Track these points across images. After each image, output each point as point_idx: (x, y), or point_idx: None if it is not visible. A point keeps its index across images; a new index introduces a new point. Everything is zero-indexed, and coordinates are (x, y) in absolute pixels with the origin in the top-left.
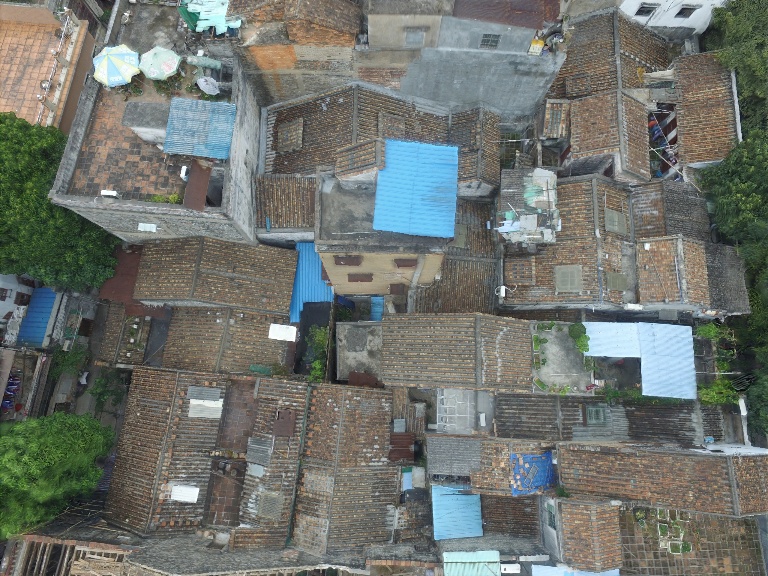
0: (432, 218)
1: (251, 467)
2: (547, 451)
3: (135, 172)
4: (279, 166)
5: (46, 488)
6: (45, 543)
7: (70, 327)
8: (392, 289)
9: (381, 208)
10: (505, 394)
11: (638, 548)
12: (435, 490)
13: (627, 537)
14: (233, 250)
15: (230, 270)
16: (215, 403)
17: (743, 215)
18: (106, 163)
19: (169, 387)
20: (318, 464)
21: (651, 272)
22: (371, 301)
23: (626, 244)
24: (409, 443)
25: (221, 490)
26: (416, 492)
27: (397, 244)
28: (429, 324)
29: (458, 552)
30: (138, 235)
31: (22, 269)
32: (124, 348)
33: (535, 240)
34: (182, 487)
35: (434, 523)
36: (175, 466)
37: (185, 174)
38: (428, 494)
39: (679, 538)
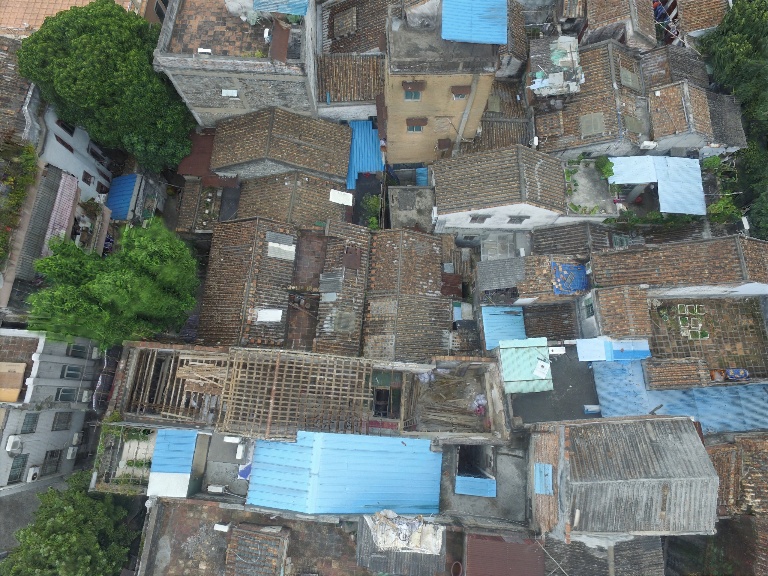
0: (489, 30)
1: (325, 295)
2: (581, 265)
3: (222, 39)
4: (336, 50)
5: (158, 296)
6: (144, 370)
7: (147, 209)
8: (440, 144)
9: (447, 23)
10: (541, 230)
11: (663, 338)
12: (484, 311)
13: (653, 330)
14: (298, 121)
15: (297, 137)
16: (289, 247)
17: (738, 57)
18: (197, 33)
19: (250, 232)
20: (382, 294)
21: (662, 113)
22: (416, 172)
23: (639, 98)
24: (457, 282)
25: (297, 322)
26: (466, 323)
27: (458, 60)
28: (476, 160)
29: (512, 340)
30: (214, 112)
31: (118, 137)
32: (200, 217)
33: (562, 92)
34: (267, 310)
35: (485, 337)
36: (259, 295)
37: (268, 35)
38: (476, 325)
39: (697, 327)
